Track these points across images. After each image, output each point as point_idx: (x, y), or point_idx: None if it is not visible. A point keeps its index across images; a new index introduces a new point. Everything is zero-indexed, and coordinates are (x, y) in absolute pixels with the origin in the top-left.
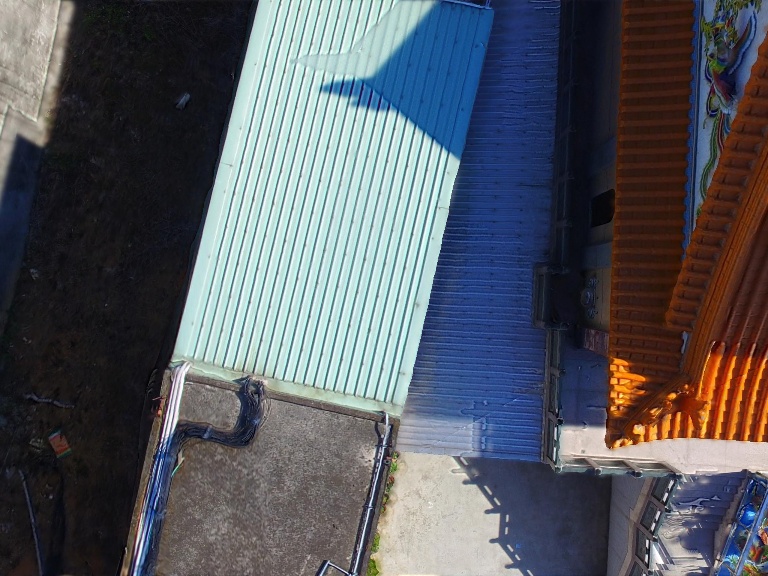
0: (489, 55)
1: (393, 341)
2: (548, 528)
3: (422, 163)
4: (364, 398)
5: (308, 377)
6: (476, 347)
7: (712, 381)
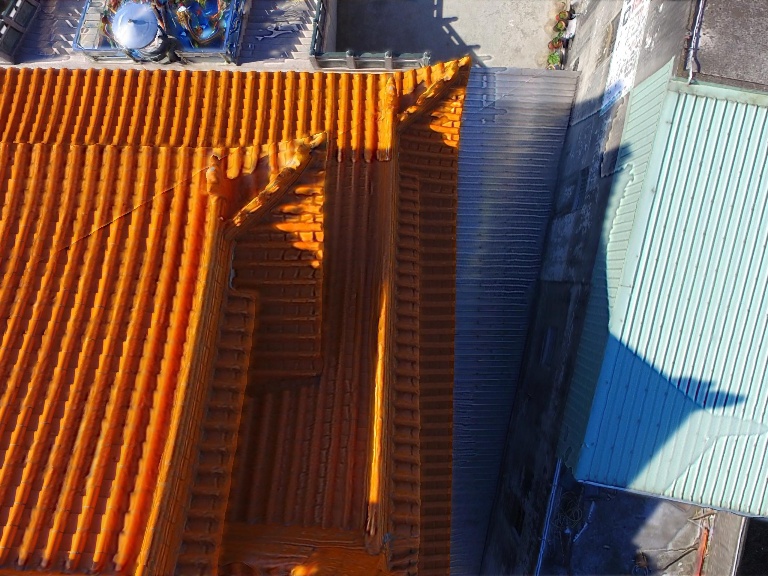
0: (488, 460)
1: (678, 154)
2: (396, 6)
3: (647, 330)
4: (708, 97)
5: (764, 116)
6: (495, 176)
7: (370, 127)
